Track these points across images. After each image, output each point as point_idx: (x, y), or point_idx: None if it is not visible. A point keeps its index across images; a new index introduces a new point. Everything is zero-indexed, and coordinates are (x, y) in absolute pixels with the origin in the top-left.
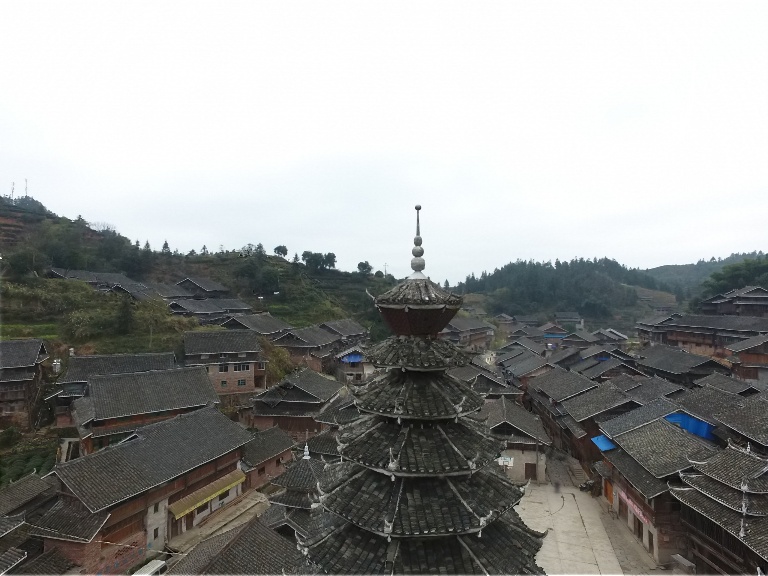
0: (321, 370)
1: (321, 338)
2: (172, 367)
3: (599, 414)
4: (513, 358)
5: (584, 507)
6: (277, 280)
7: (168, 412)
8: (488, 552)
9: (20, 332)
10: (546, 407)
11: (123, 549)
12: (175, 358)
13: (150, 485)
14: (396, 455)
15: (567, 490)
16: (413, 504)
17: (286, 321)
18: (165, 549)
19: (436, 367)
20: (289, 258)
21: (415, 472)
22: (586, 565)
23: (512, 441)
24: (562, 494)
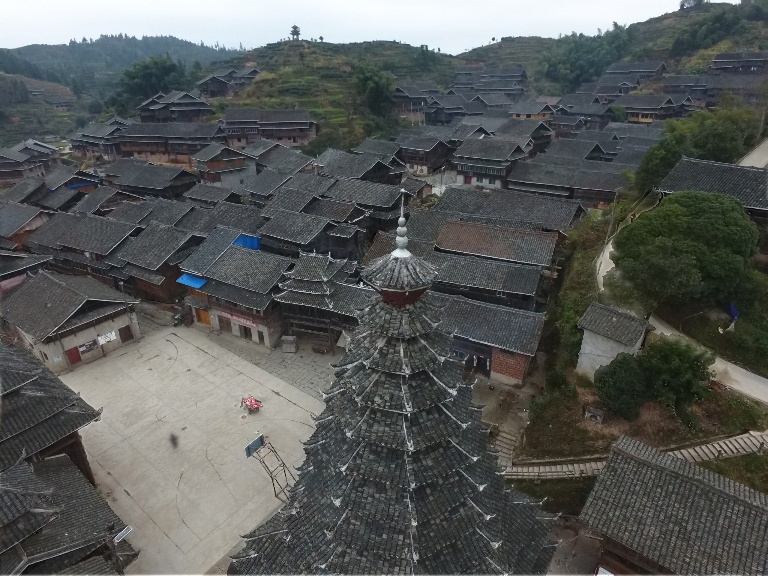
0: None
1: None
2: None
3: (171, 256)
4: None
5: (191, 339)
6: None
7: None
8: None
9: None
10: (84, 263)
11: None
12: None
13: None
14: None
15: (165, 333)
16: None
17: None
18: None
19: None
20: None
21: None
22: (236, 378)
23: (101, 315)
24: (165, 338)
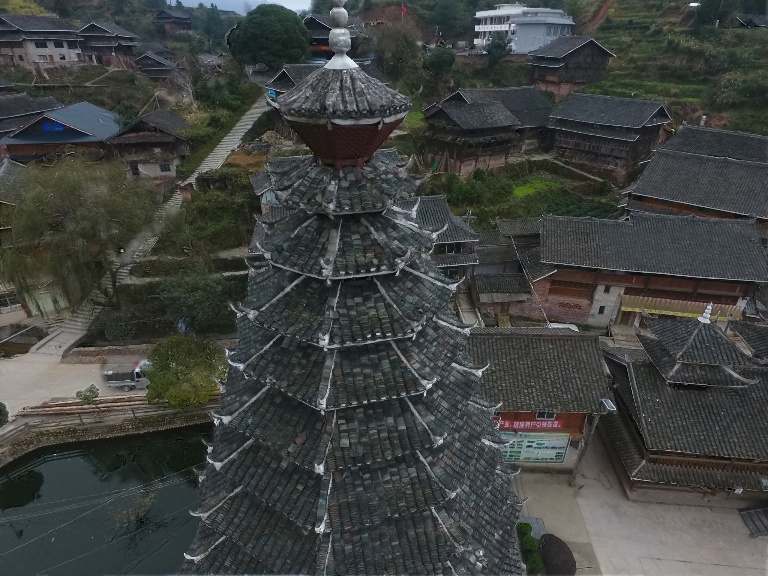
0: None
1: None
2: None
3: None
4: None
5: None
6: None
7: (713, 211)
8: (272, 407)
9: (667, 92)
10: None
11: (567, 304)
12: None
13: (598, 265)
14: (254, 266)
15: None
16: None
17: None
18: (607, 328)
19: None
20: None
21: None
22: None
23: None
24: None
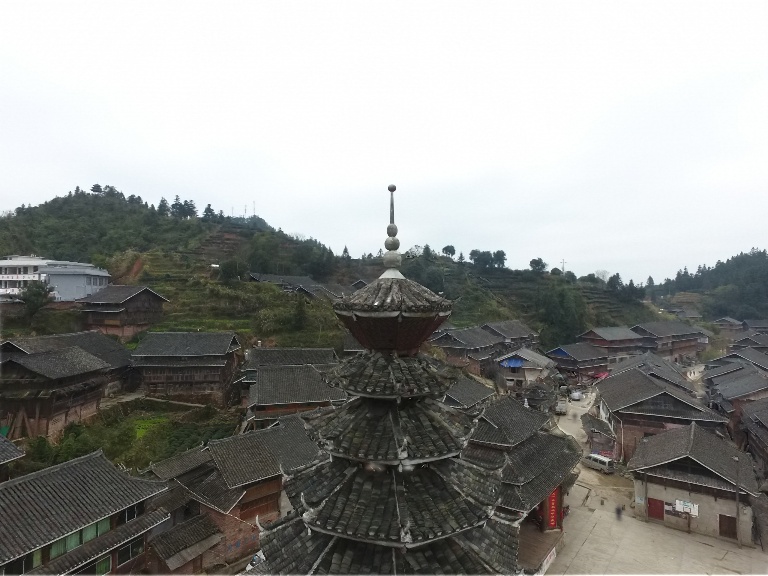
0: (479, 373)
1: (481, 340)
2: (330, 362)
3: None
4: (728, 374)
5: None
6: (442, 280)
7: (317, 404)
8: None
9: (225, 326)
10: (765, 443)
11: None
12: (335, 353)
13: None
14: (314, 503)
15: None
16: (335, 570)
17: (449, 321)
18: None
19: (382, 394)
20: (454, 258)
21: (331, 530)
22: None
23: (698, 483)
24: None
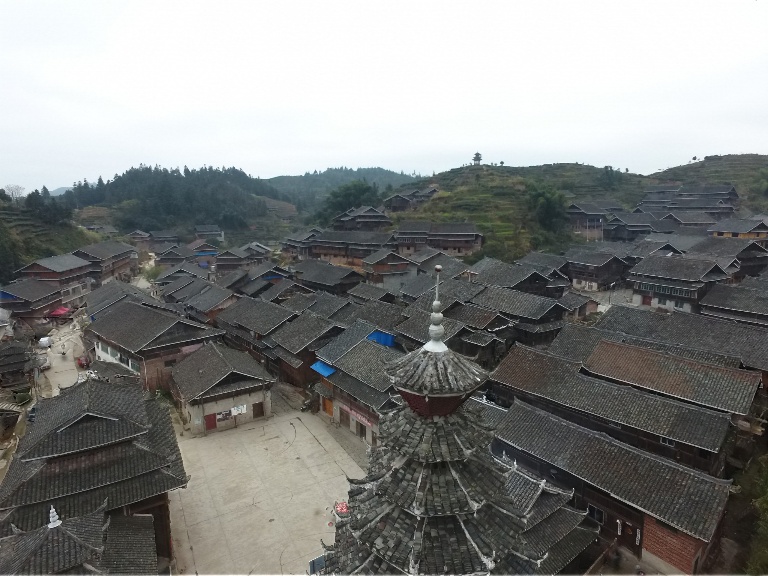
0: None
1: None
2: None
3: (312, 343)
4: (183, 288)
5: (312, 426)
6: None
7: None
8: None
9: None
10: (248, 341)
11: None
12: None
13: None
14: None
15: (292, 416)
16: None
17: None
18: None
19: None
20: None
21: None
22: (338, 478)
23: (240, 388)
24: (290, 421)
